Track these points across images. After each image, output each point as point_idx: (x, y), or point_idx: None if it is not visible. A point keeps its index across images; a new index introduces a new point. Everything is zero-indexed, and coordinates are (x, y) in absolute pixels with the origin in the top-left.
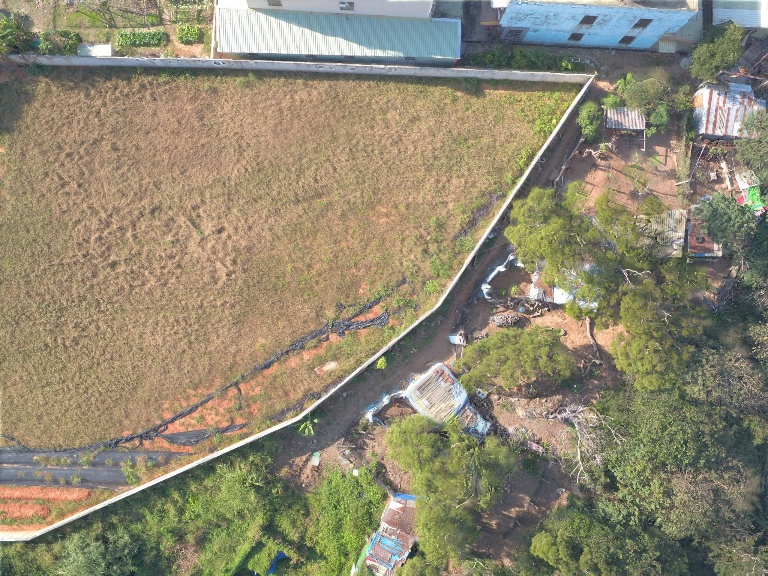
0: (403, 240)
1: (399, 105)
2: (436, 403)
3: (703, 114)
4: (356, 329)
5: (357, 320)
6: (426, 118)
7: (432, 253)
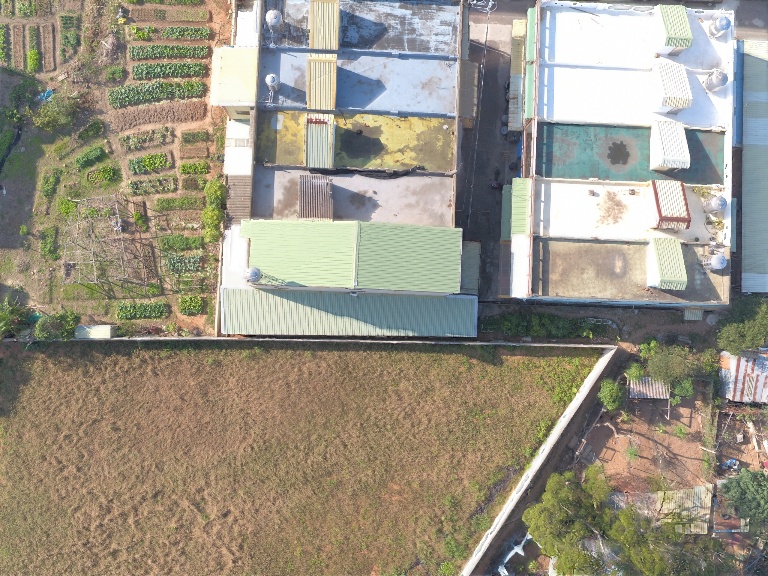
0: (417, 519)
1: (412, 376)
2: None
3: (730, 381)
4: None
5: None
6: (440, 389)
7: (447, 533)
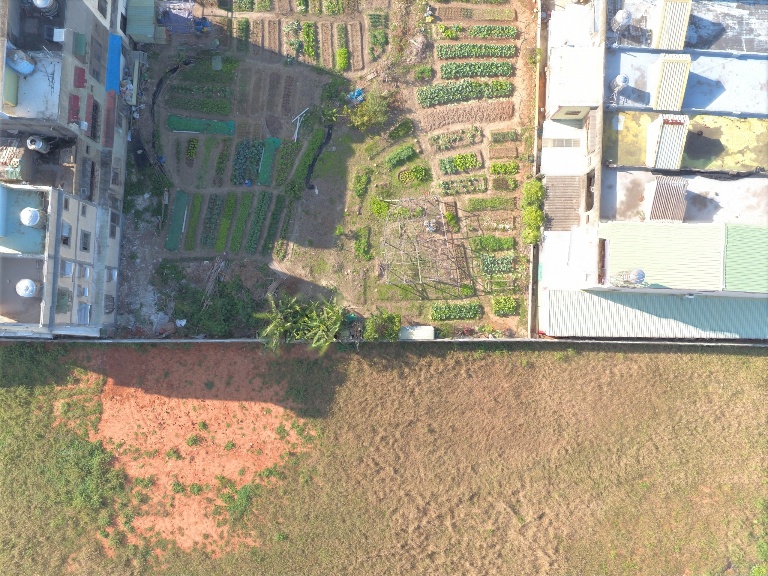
0: (728, 523)
1: (722, 379)
2: None
3: None
4: None
5: None
6: (750, 391)
7: (758, 536)
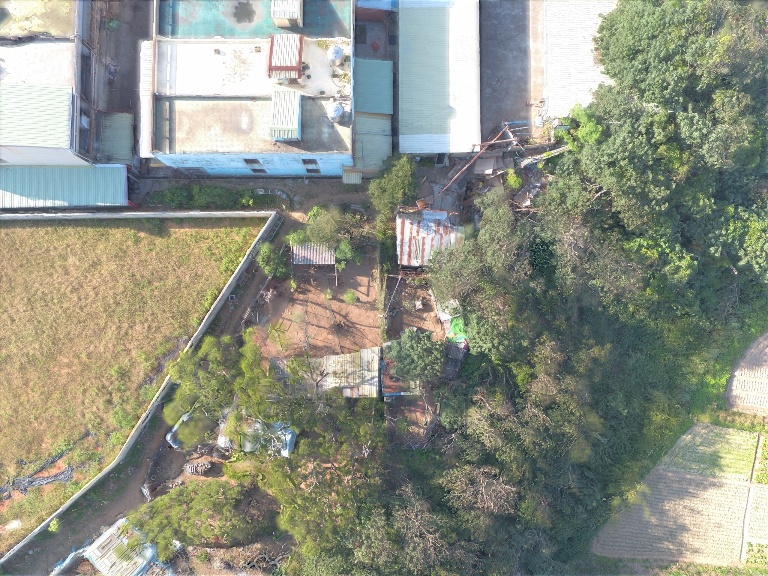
0: (85, 391)
1: (79, 251)
2: (117, 561)
3: (397, 244)
4: (38, 485)
5: (40, 476)
6: (108, 262)
7: (115, 403)
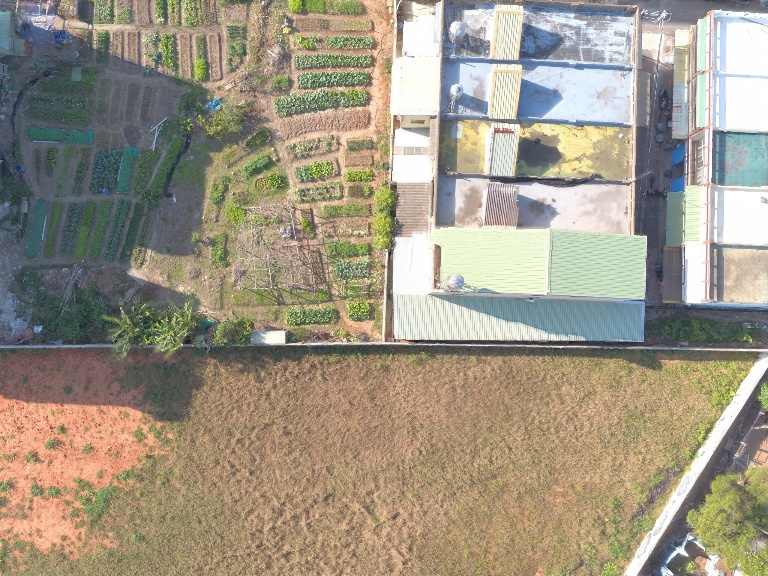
0: (580, 521)
1: (575, 380)
2: None
3: None
4: None
5: None
6: (602, 392)
7: (610, 534)
